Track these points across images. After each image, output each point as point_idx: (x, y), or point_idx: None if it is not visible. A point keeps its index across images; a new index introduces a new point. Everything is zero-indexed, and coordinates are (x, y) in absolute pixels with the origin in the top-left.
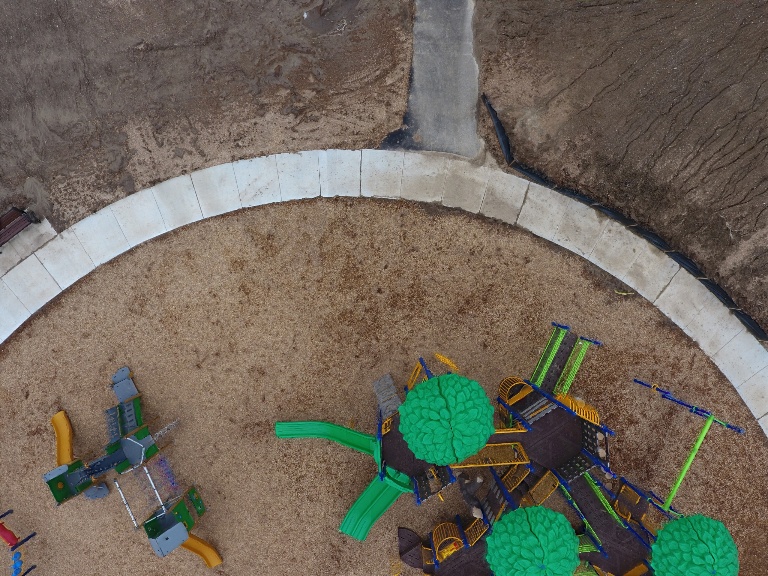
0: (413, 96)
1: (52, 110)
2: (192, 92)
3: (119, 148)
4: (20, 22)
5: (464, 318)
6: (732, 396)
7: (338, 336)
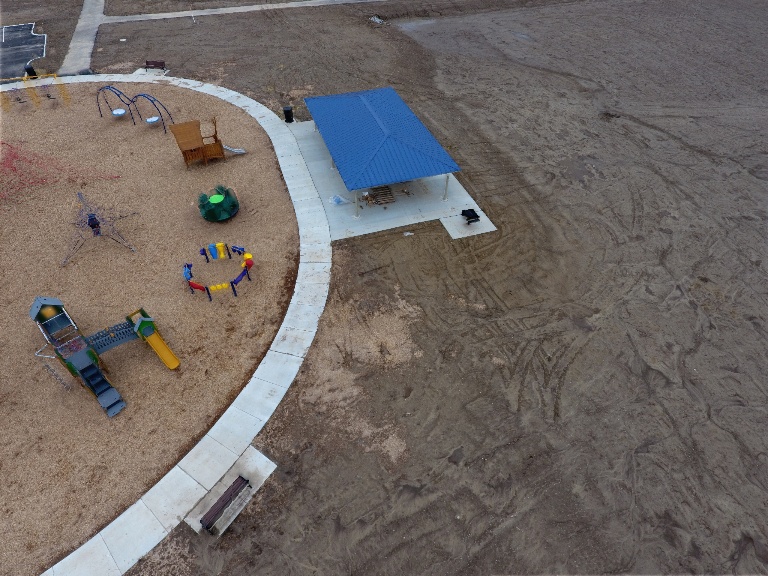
0: None
1: None
2: None
3: None
4: None
5: None
6: None
7: None
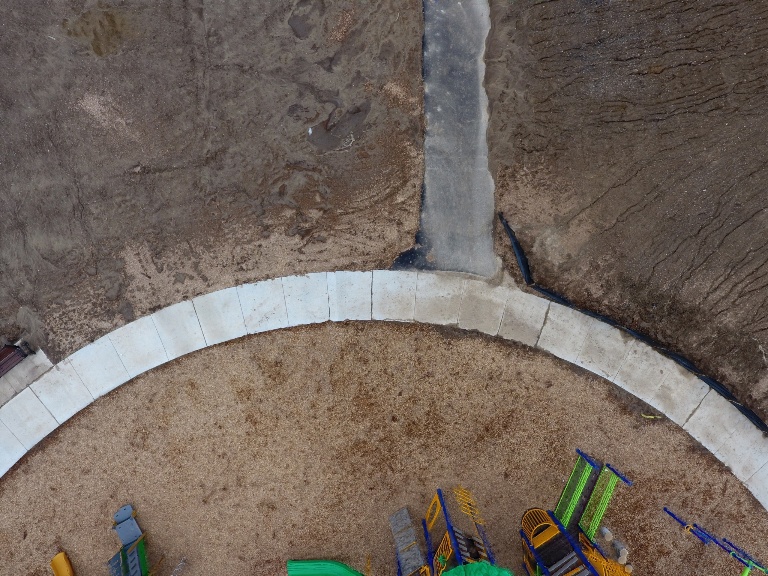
0: (426, 214)
1: (45, 237)
2: (192, 215)
3: (116, 275)
4: (9, 148)
5: (483, 446)
6: (767, 523)
7: (351, 468)
